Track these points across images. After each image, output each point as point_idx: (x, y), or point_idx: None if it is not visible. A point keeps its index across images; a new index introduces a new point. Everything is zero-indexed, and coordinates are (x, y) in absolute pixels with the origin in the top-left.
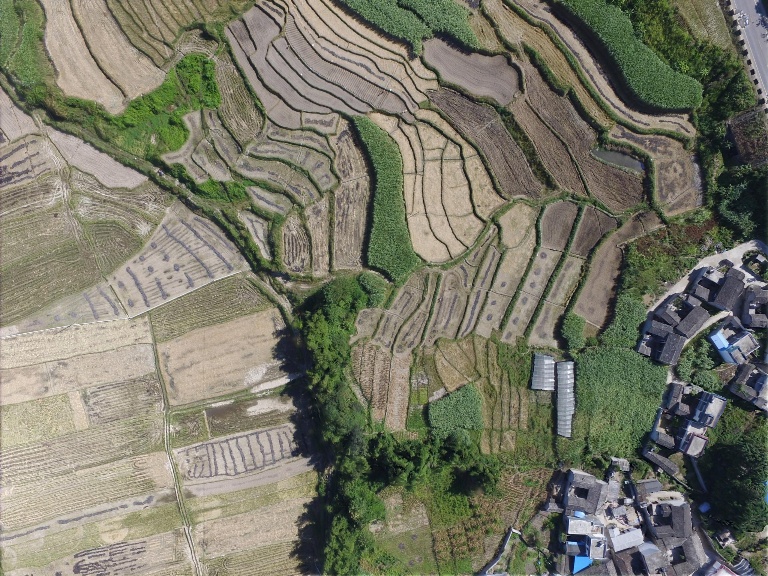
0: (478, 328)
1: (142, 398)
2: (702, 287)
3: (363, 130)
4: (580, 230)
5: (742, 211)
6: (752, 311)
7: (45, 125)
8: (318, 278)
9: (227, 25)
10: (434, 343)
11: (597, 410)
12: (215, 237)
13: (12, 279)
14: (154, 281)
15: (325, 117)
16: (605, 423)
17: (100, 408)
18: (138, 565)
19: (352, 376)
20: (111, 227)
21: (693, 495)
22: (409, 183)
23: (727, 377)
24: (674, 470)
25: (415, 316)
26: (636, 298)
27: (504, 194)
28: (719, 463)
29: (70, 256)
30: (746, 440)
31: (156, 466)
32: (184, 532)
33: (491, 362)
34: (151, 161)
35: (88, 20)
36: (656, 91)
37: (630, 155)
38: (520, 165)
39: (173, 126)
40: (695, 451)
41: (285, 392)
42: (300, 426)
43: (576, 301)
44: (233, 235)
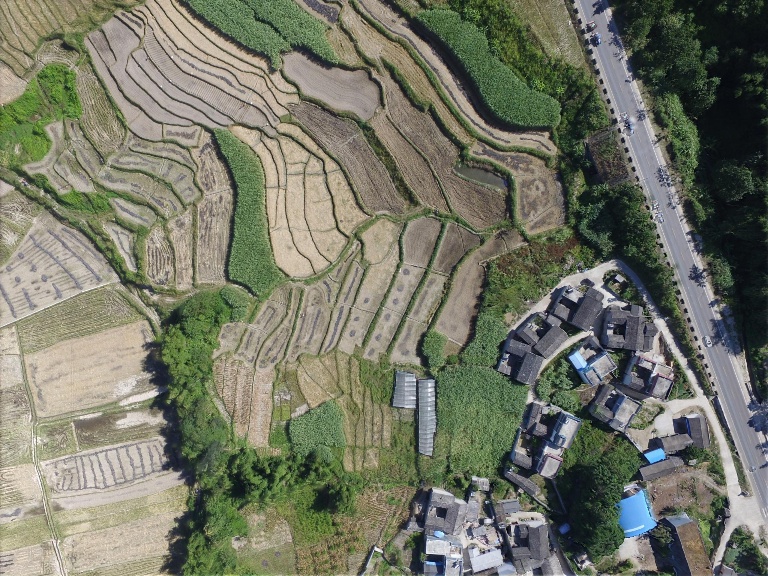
0: (341, 344)
1: (9, 409)
2: (562, 306)
3: (223, 143)
4: (443, 247)
5: (601, 230)
6: (610, 331)
7: None
8: (182, 291)
9: (87, 36)
10: (297, 359)
11: (458, 429)
12: (83, 248)
13: None
14: (21, 292)
15: (187, 129)
16: (466, 442)
17: None
18: None
19: (215, 391)
20: None
21: (554, 516)
22: (272, 197)
23: (587, 397)
24: (534, 491)
25: (278, 331)
26: (497, 316)
27: (366, 210)
28: (577, 484)
29: None
30: (604, 462)
31: (24, 478)
32: (52, 545)
33: (354, 379)
34: (15, 171)
35: None
36: (512, 109)
37: (493, 172)
38: (383, 181)
39: (36, 136)
40: (549, 472)
41: (155, 405)
42: (171, 440)
43: (438, 318)
44: (99, 246)
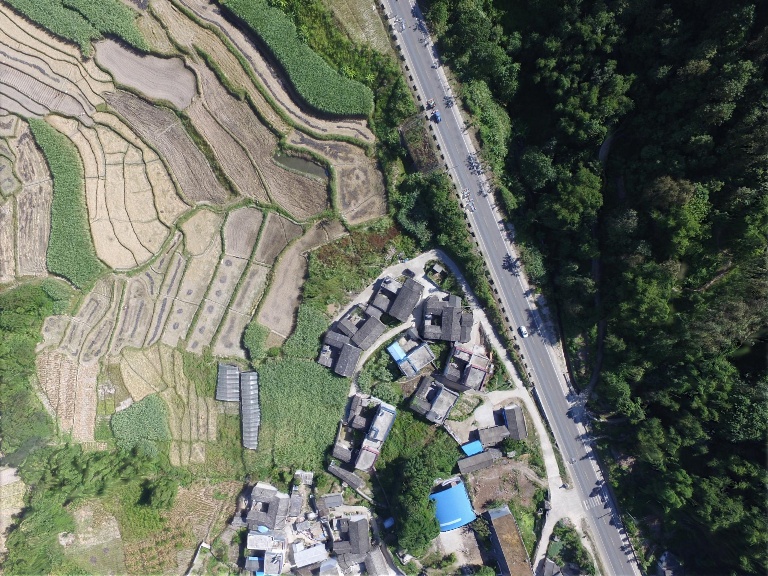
0: (164, 337)
1: None
2: (382, 297)
3: (37, 133)
4: (265, 237)
5: (418, 220)
6: (428, 322)
7: None
8: (4, 284)
9: None
10: (120, 352)
11: (281, 422)
12: None
13: None
14: None
15: (3, 119)
16: (290, 435)
17: None
18: None
19: (38, 385)
20: None
21: (378, 510)
22: (91, 187)
23: (409, 389)
24: (357, 484)
25: (101, 324)
26: (318, 308)
27: (186, 200)
28: (397, 478)
29: None
30: (423, 454)
31: None
32: None
33: (177, 372)
34: None
35: None
36: (322, 96)
37: (313, 161)
38: (203, 170)
39: None
40: (365, 465)
41: None
42: None
43: (259, 310)
44: None
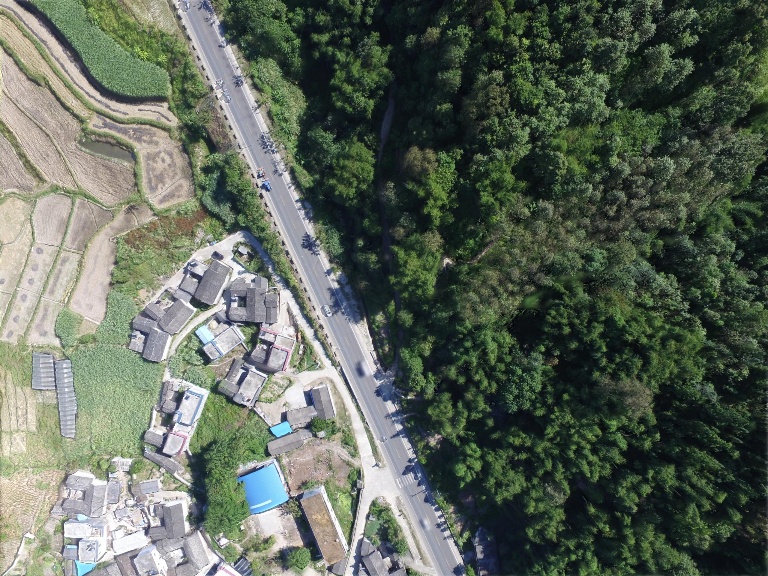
0: None
1: None
2: (190, 280)
3: None
4: (74, 224)
5: (221, 201)
6: (235, 304)
7: None
8: None
9: None
10: None
11: (96, 409)
12: None
13: None
14: None
15: None
16: (106, 422)
17: None
18: None
19: None
20: None
21: (197, 494)
22: None
23: (222, 373)
24: (173, 469)
25: None
26: (129, 293)
27: None
28: None
29: None
30: (235, 437)
31: None
32: None
33: None
34: None
35: None
36: (116, 79)
37: (118, 146)
38: (9, 158)
39: None
40: (173, 450)
41: None
42: None
43: (71, 297)
44: None
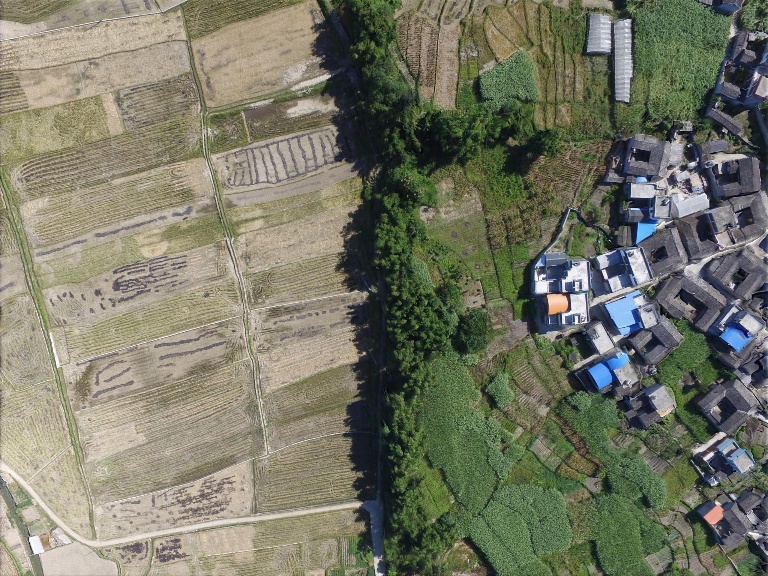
0: None
1: (178, 100)
2: None
3: None
4: None
5: None
6: None
7: None
8: None
9: None
10: (483, 11)
11: (657, 70)
12: None
13: None
14: None
15: None
16: (665, 84)
17: (134, 111)
18: (179, 281)
19: (398, 52)
20: None
21: (759, 156)
22: None
23: None
24: (739, 128)
25: None
26: None
27: None
28: None
29: None
30: None
31: (195, 173)
32: (226, 245)
33: (544, 28)
34: None
35: None
36: None
37: None
38: None
39: None
40: (764, 93)
41: (326, 91)
42: (343, 128)
43: None
44: None
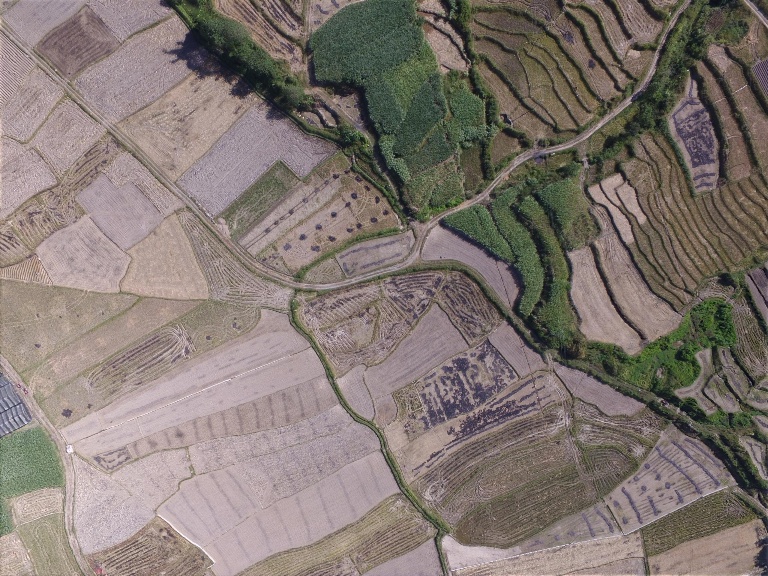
0: None
1: None
2: None
3: None
4: None
5: None
6: None
7: (553, 362)
8: None
9: (747, 273)
10: None
11: None
12: (704, 456)
13: (517, 504)
14: (647, 499)
15: None
16: None
17: None
18: None
19: None
20: (609, 451)
21: None
22: None
23: None
24: None
25: None
26: None
27: None
28: None
29: (570, 480)
30: None
31: None
32: None
33: None
34: (656, 393)
35: (612, 272)
36: None
37: None
38: None
39: (681, 361)
40: None
41: None
42: None
43: None
44: (729, 457)
